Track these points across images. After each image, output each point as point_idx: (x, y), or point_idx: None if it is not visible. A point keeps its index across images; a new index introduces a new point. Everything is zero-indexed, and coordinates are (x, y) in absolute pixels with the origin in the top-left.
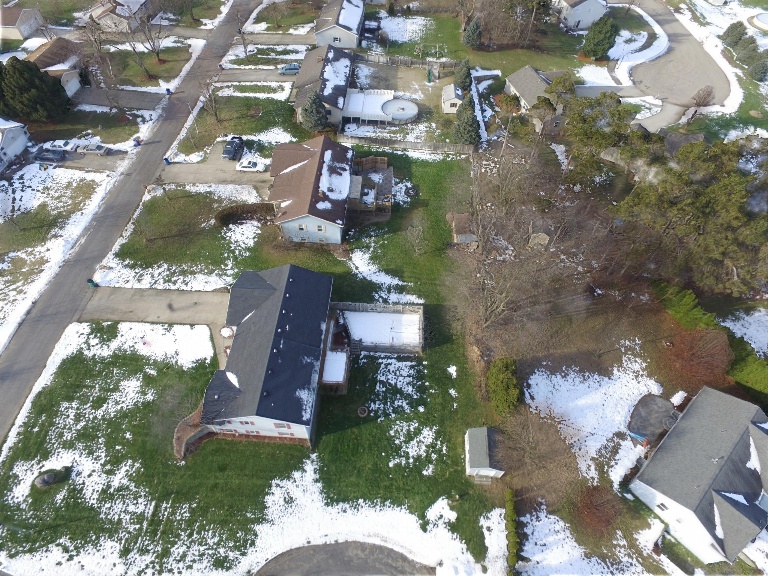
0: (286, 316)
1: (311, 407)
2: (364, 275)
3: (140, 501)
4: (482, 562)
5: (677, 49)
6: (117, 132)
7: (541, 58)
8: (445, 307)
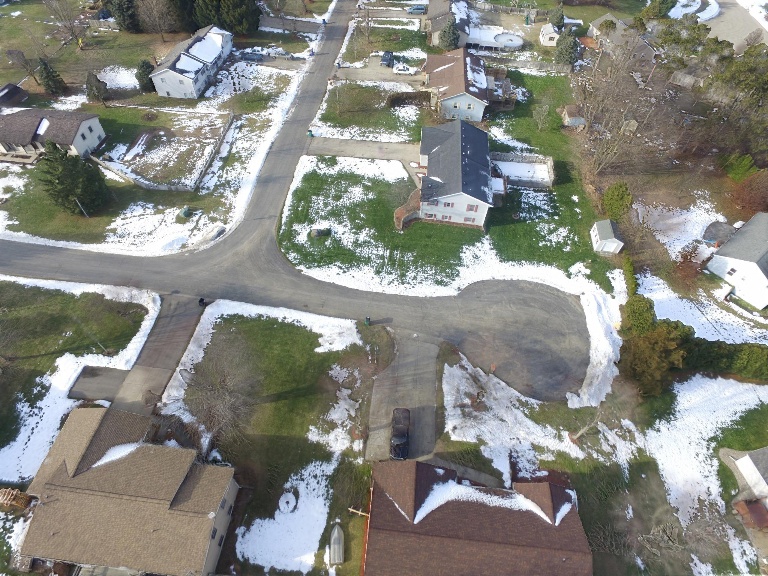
0: (465, 147)
1: (492, 197)
2: (502, 141)
3: (379, 249)
4: (611, 293)
5: (727, 13)
6: (294, 46)
7: (614, 13)
8: (565, 162)
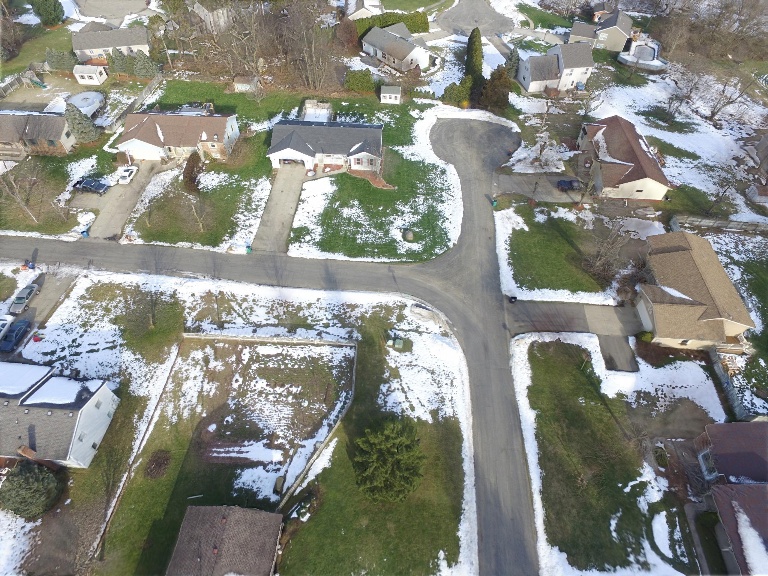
0: None
1: None
2: (271, 126)
3: (417, 200)
4: (434, 105)
5: None
6: None
7: (43, 40)
8: (303, 100)
